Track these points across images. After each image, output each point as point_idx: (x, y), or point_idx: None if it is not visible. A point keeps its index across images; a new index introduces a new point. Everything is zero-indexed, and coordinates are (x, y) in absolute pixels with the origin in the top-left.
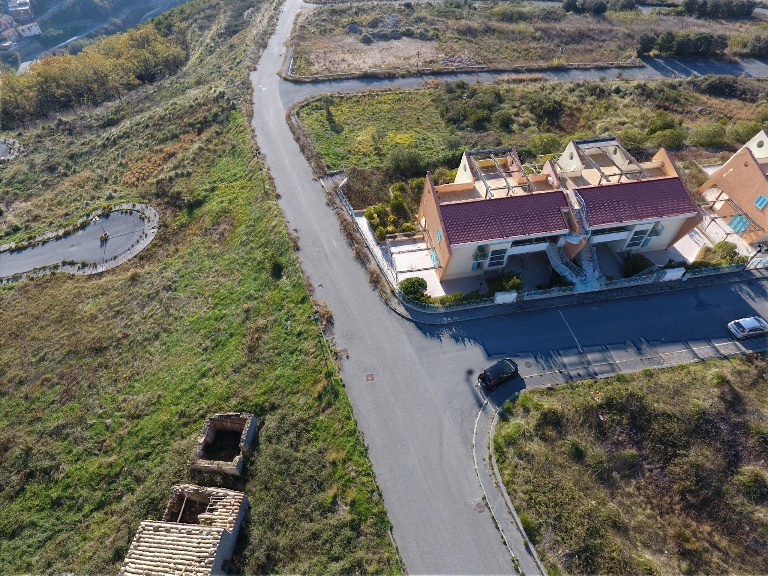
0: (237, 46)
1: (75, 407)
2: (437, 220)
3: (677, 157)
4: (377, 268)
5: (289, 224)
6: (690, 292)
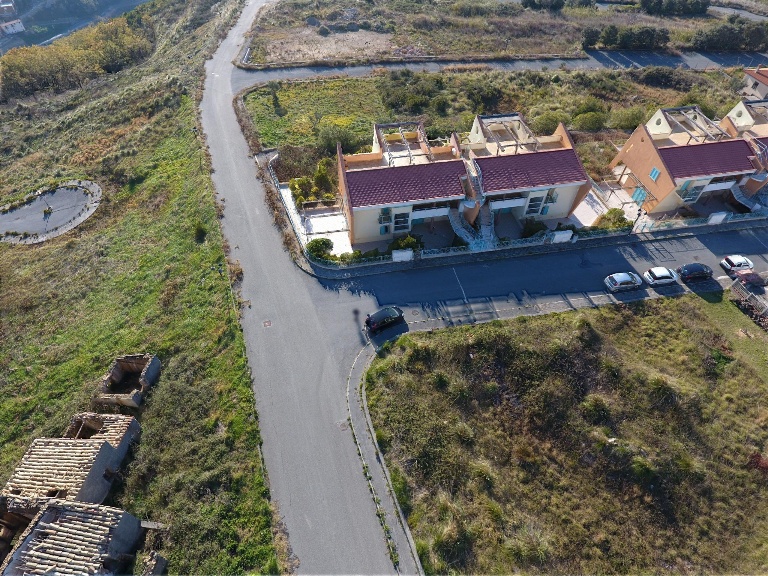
0: (199, 37)
1: (0, 357)
2: (344, 186)
3: (594, 137)
4: (292, 232)
5: (218, 195)
6: (577, 252)
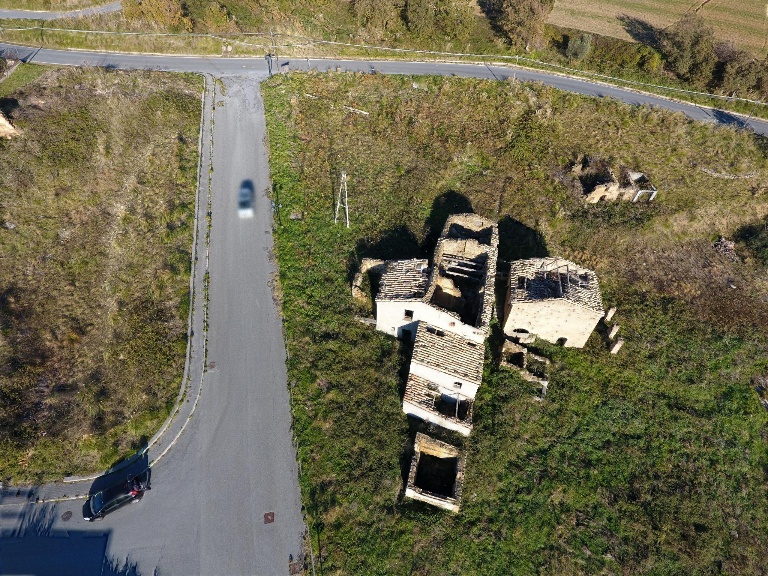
0: None
1: None
2: None
3: None
4: None
5: None
6: None
